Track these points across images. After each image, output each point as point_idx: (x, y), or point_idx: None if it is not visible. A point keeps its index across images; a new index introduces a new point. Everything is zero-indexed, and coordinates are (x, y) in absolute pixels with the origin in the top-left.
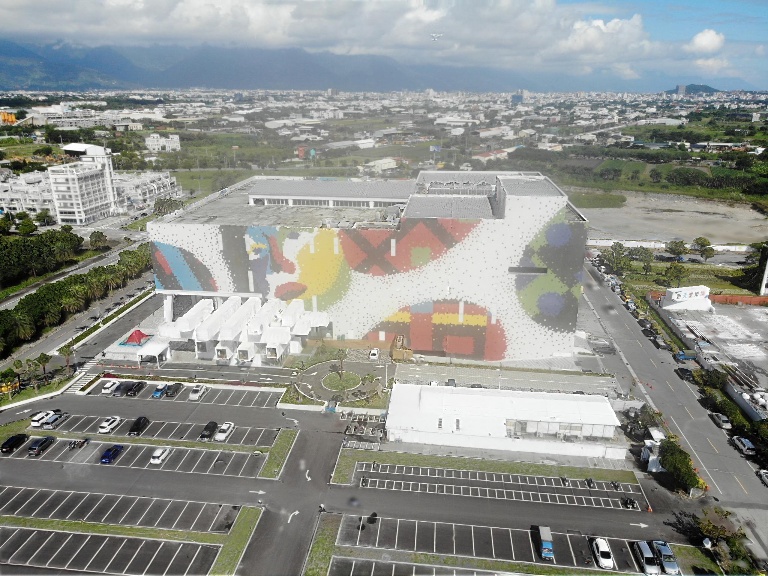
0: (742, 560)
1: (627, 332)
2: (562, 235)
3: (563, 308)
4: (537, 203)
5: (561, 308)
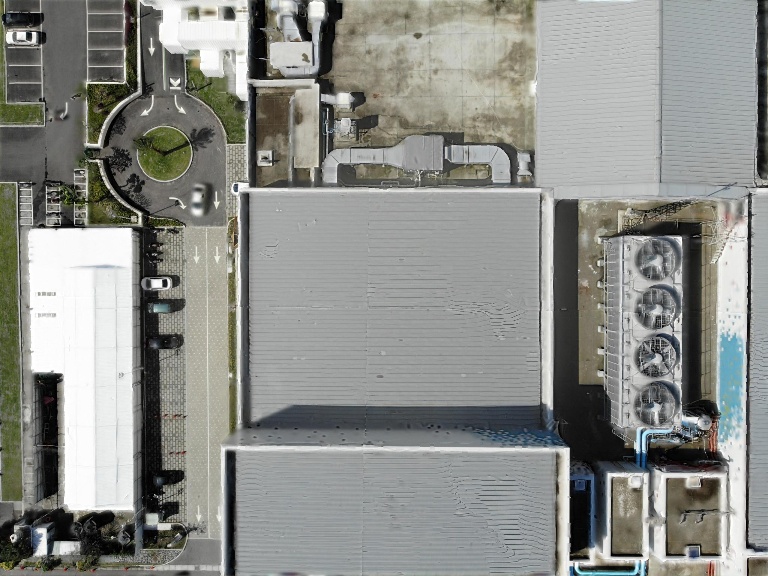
0: None
1: None
2: None
3: None
4: None
5: None
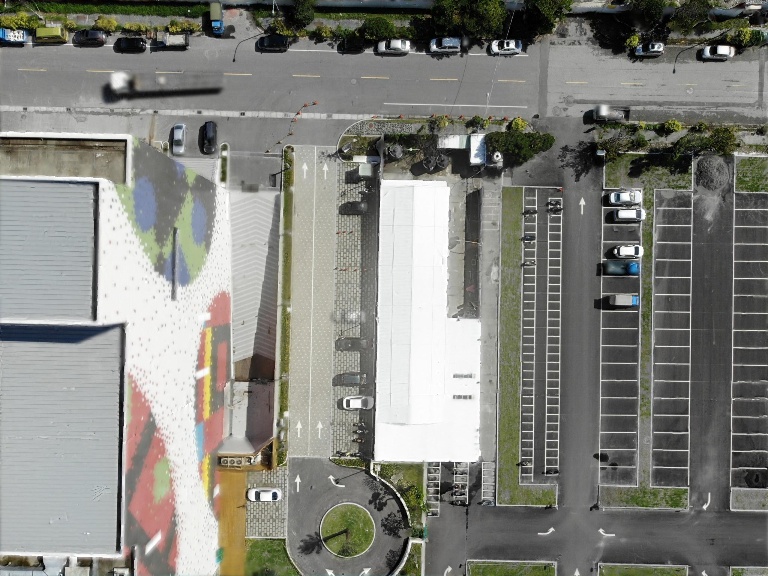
0: (616, 130)
1: (127, 80)
2: (146, 197)
3: (202, 202)
4: (110, 251)
5: (202, 206)
